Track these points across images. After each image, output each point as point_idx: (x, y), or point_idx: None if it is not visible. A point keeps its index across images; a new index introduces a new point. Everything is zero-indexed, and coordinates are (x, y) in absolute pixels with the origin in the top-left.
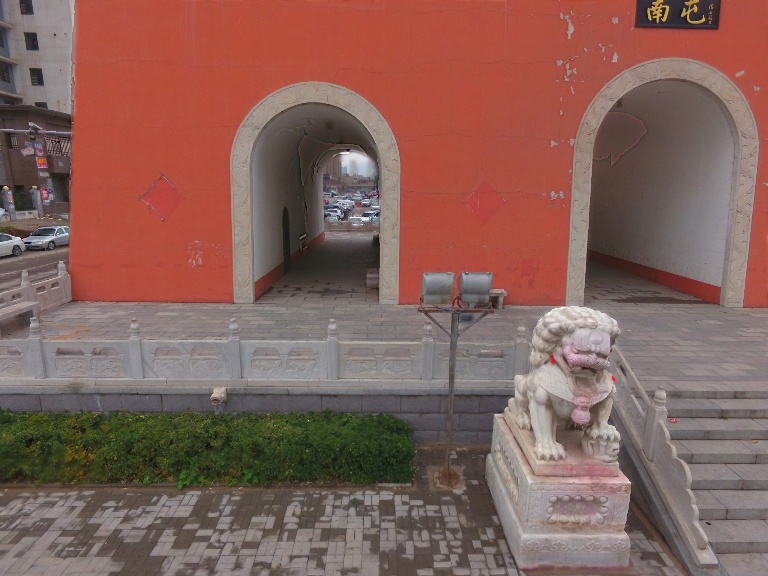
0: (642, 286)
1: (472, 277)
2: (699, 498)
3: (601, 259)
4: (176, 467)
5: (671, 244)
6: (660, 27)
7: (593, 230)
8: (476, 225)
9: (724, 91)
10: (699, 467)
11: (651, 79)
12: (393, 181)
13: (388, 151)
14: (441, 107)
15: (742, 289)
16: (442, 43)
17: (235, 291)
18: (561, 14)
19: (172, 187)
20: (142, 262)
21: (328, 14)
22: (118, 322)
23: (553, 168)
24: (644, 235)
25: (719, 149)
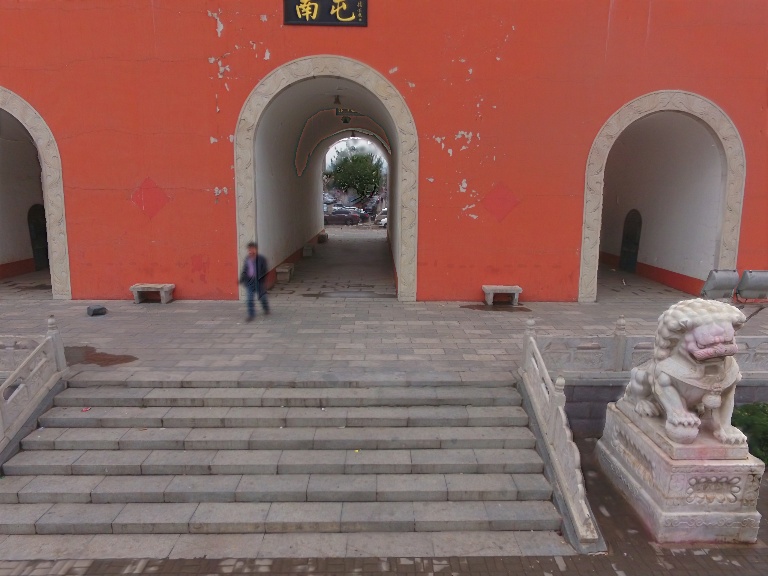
0: (372, 281)
1: None
2: (11, 483)
3: None
4: None
5: None
6: (309, 24)
7: None
8: (143, 221)
9: (379, 88)
10: (54, 453)
11: (304, 76)
12: (55, 177)
13: (47, 148)
14: (97, 104)
15: (414, 283)
16: (92, 41)
17: None
18: (209, 12)
19: None
20: None
21: None
22: None
23: (215, 164)
24: (394, 230)
25: (398, 145)
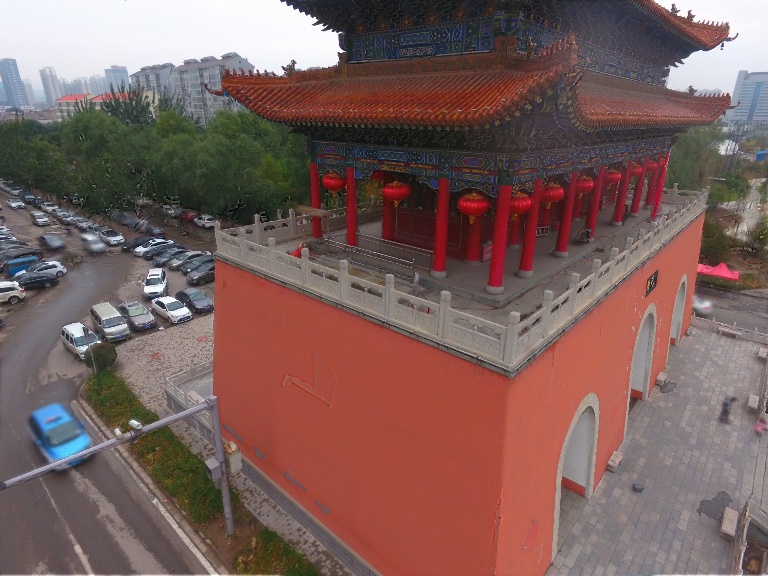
0: None
1: None
2: None
3: None
4: None
5: None
6: None
7: None
8: None
9: None
10: None
11: None
12: None
13: None
14: None
15: None
16: None
17: None
18: None
19: None
20: None
21: (589, 354)
22: None
23: None
24: None
25: None
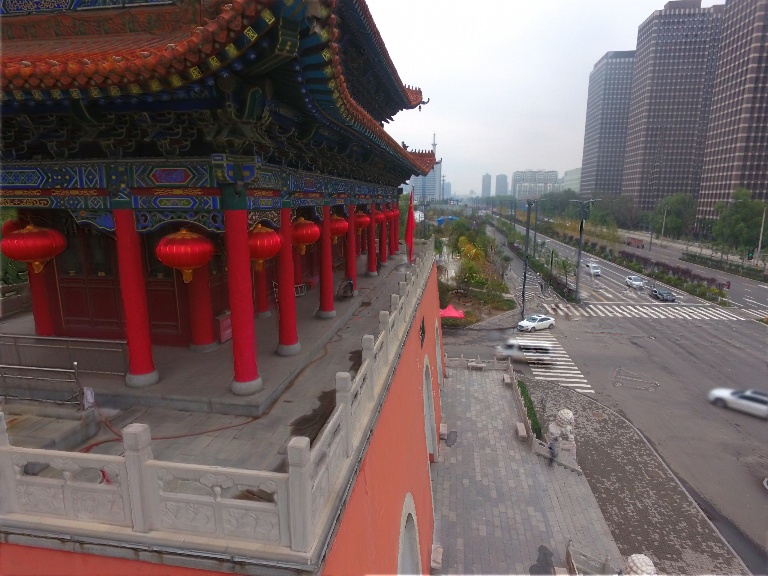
0: None
1: None
2: None
3: None
4: None
5: None
6: None
7: None
8: None
9: None
10: None
11: None
12: None
13: None
14: None
15: None
16: None
17: None
18: None
19: None
20: None
21: None
22: None
23: None
24: None
25: None
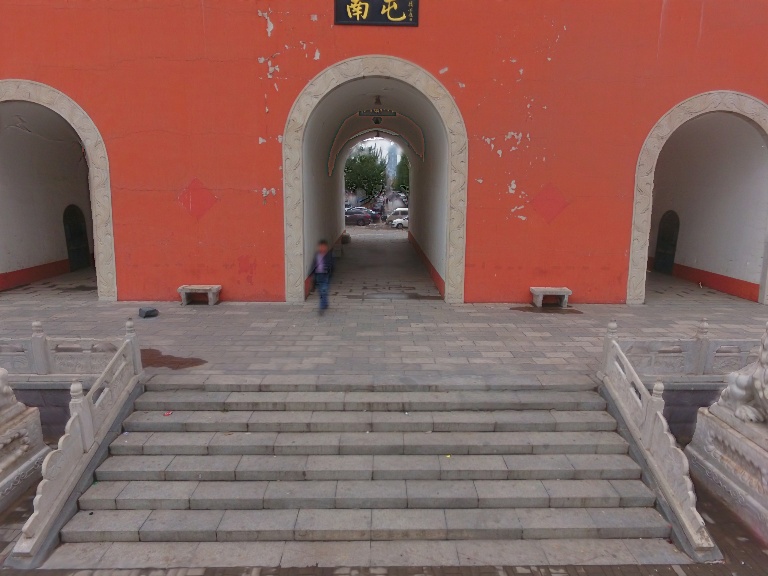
0: (411, 282)
1: None
2: (106, 489)
3: (421, 256)
4: None
5: (435, 240)
6: (359, 24)
7: (420, 227)
8: (190, 222)
9: (429, 88)
10: (143, 459)
11: (354, 76)
12: (102, 178)
13: (95, 148)
14: (145, 104)
15: (462, 285)
16: (142, 40)
17: None
18: (259, 11)
19: None
20: None
21: (24, 11)
22: None
23: (263, 165)
24: None
25: (445, 146)
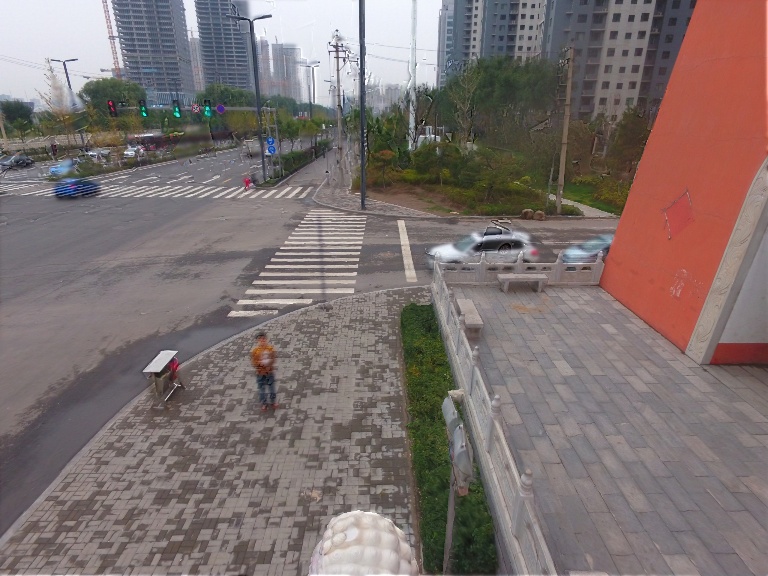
0: None
1: (458, 435)
2: None
3: None
4: (421, 416)
5: None
6: None
7: None
8: None
9: None
10: None
11: None
12: None
13: None
14: None
15: None
16: None
17: (691, 341)
18: None
19: (690, 205)
20: (643, 273)
21: None
22: (568, 315)
23: None
24: None
25: None
